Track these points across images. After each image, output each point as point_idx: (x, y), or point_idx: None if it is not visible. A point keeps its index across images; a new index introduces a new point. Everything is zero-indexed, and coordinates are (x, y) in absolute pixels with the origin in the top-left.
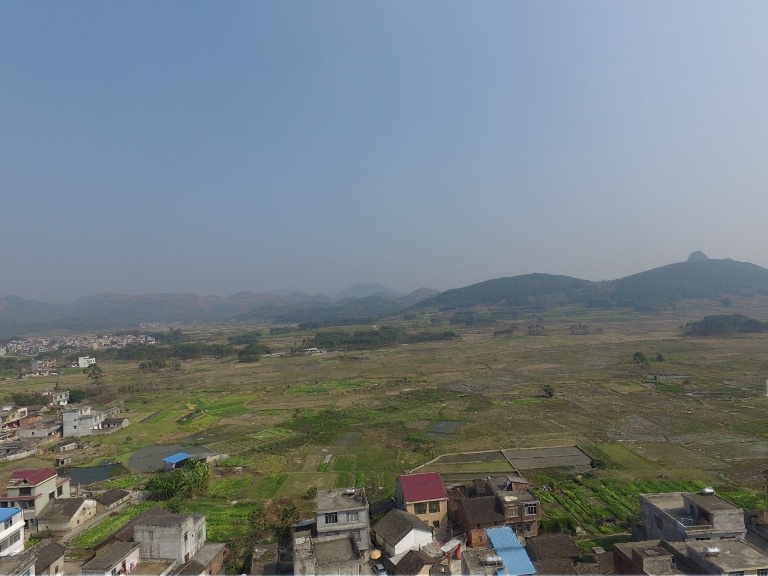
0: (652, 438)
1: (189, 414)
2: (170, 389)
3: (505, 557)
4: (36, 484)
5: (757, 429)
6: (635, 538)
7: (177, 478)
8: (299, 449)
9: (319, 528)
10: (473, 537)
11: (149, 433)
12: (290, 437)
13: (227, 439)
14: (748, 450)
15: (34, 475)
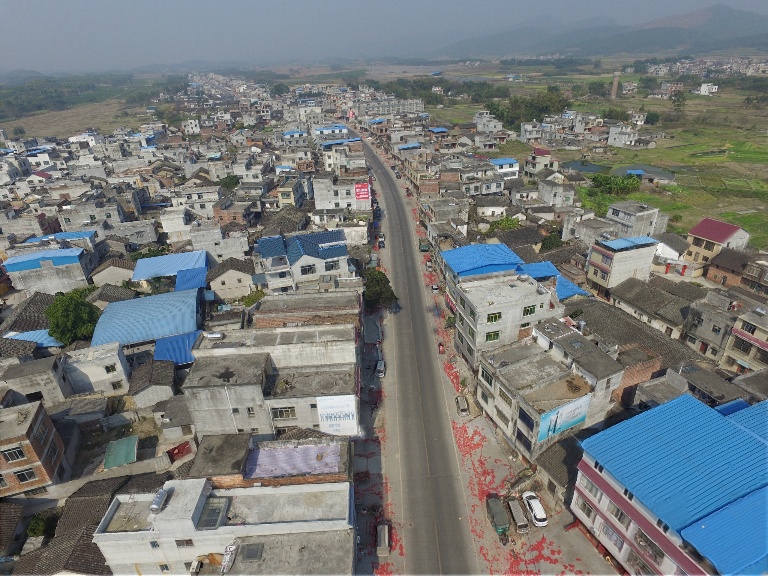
0: None
1: (710, 151)
2: (740, 128)
3: (619, 241)
4: (538, 156)
5: None
6: None
7: (608, 179)
8: (740, 199)
9: (607, 215)
10: (710, 272)
11: (658, 156)
12: (755, 190)
13: (701, 176)
14: None
15: (540, 151)
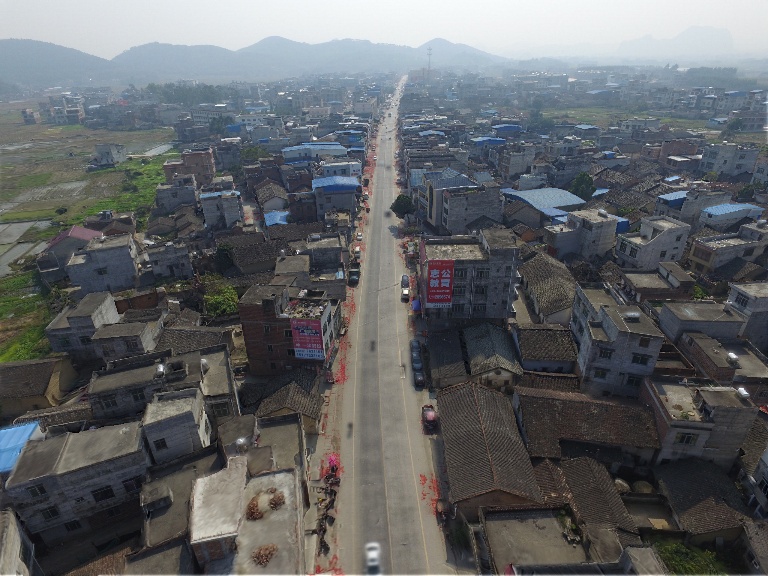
0: (7, 205)
1: None
2: None
3: (228, 193)
4: None
5: (36, 183)
6: (158, 214)
7: None
8: None
9: (132, 256)
10: None
11: None
12: None
13: None
14: (67, 189)
15: None
